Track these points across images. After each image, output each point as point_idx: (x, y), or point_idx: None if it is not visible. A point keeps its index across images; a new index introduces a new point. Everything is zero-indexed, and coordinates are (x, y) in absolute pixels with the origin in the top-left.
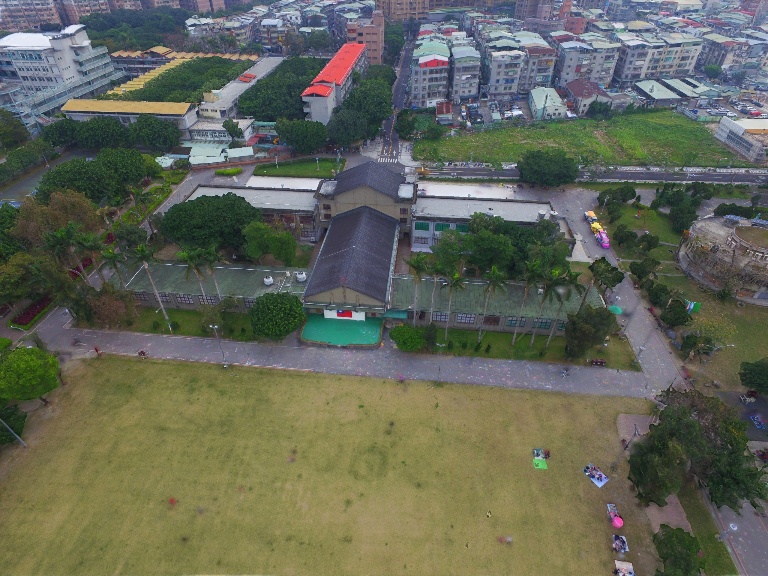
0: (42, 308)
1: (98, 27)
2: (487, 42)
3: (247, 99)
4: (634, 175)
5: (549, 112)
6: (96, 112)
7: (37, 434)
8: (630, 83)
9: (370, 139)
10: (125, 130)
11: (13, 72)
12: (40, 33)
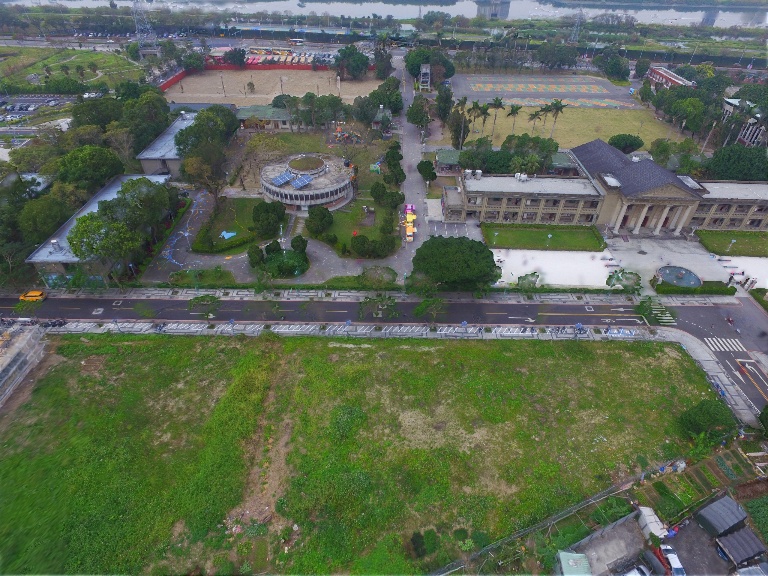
0: None
1: None
2: None
3: None
4: (304, 311)
5: None
6: None
7: None
8: None
9: None
10: None
11: None
12: None
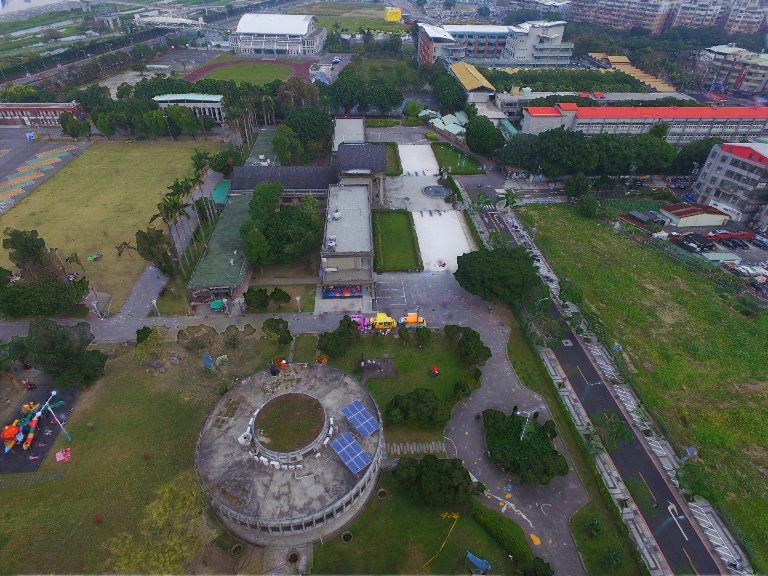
0: (259, 124)
1: (668, 38)
2: None
3: (532, 103)
4: (600, 403)
5: None
6: None
7: (179, 142)
8: None
9: (548, 179)
10: None
11: None
12: None
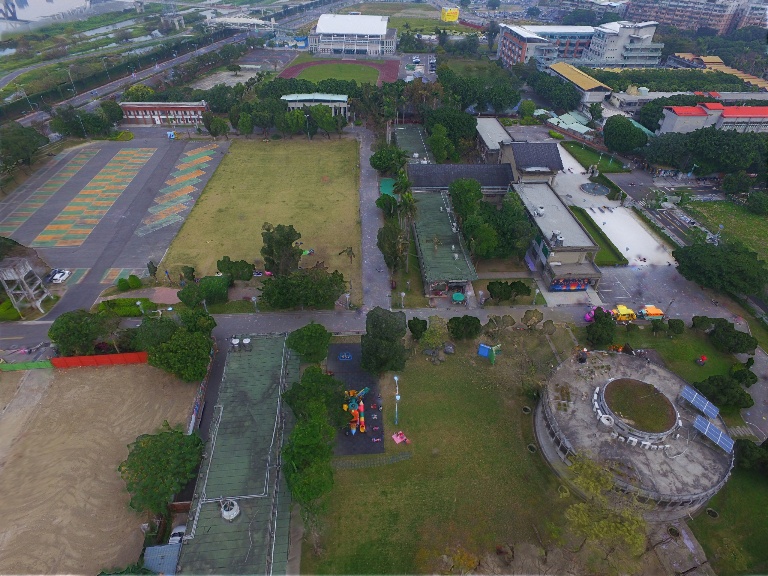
0: None
1: (740, 38)
2: None
3: (655, 102)
4: None
5: None
6: (558, 73)
7: (315, 141)
8: None
9: (695, 177)
10: None
11: None
12: None
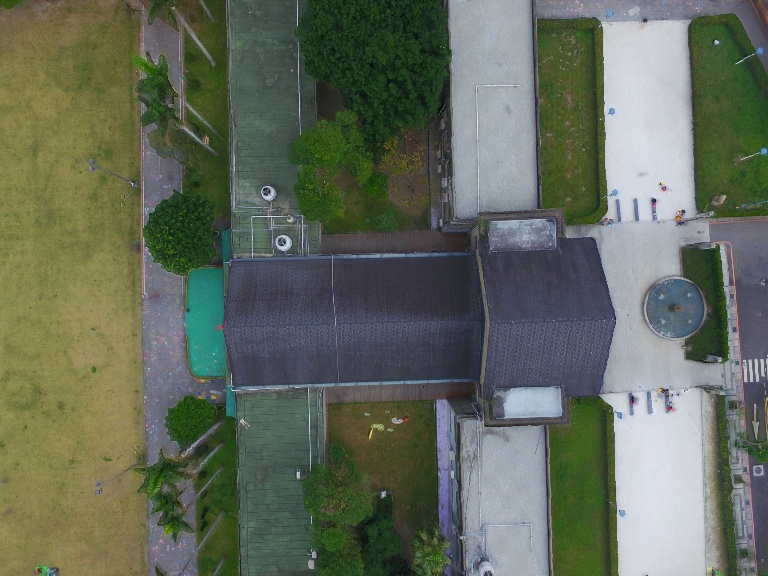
0: None
1: None
2: None
3: None
4: None
5: None
6: None
7: (13, 14)
8: None
9: None
10: None
11: None
12: None
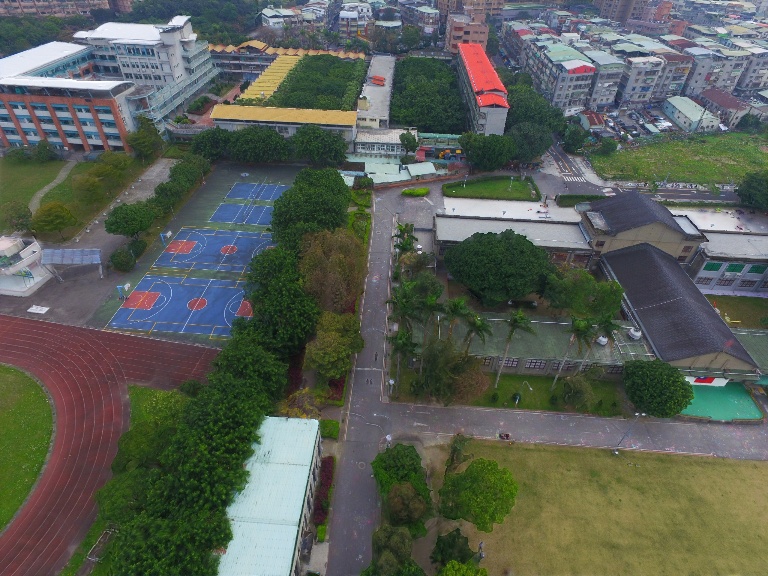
0: (344, 376)
1: (156, 14)
2: (604, 45)
3: (401, 107)
4: None
5: (703, 124)
6: (251, 121)
7: None
8: (749, 92)
9: None
10: (287, 142)
11: (106, 67)
12: (135, 24)
